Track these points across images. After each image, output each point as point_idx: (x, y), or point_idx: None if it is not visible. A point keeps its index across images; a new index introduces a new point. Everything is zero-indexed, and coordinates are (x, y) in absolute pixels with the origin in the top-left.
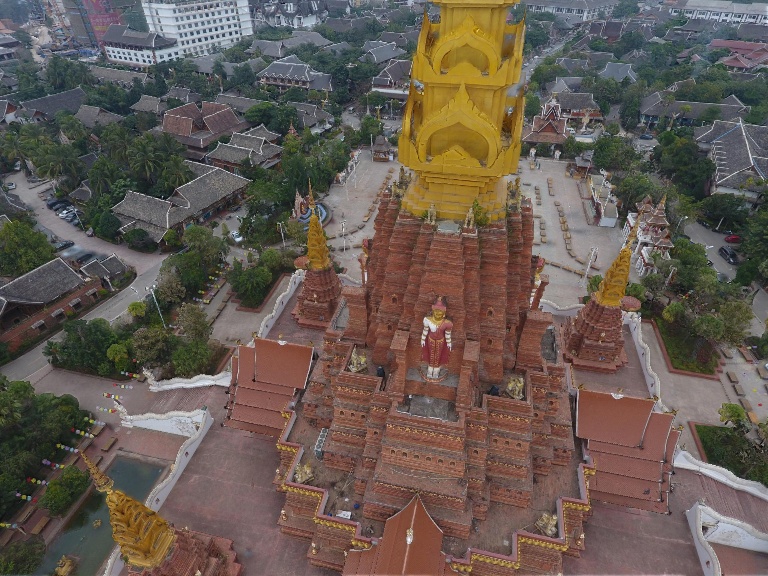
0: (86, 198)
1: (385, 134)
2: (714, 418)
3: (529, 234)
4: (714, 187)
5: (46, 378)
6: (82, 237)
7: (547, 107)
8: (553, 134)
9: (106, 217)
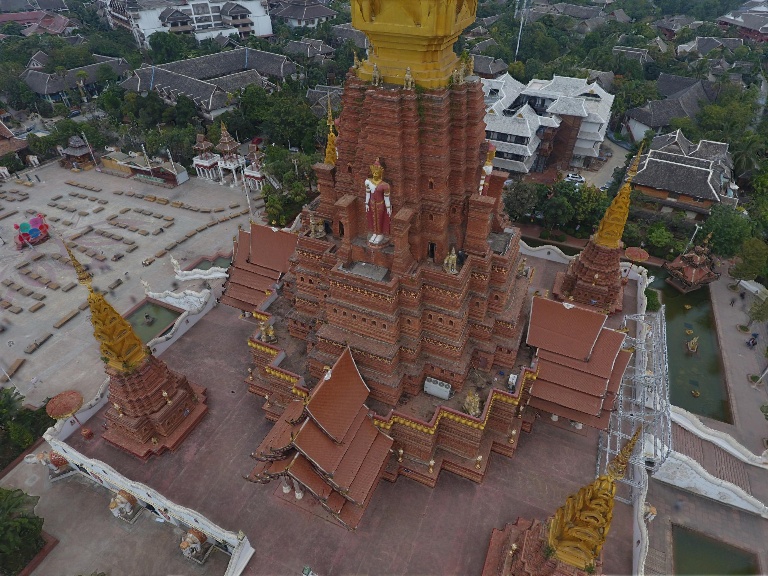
0: None
1: None
2: None
3: None
4: (206, 114)
5: None
6: None
7: None
8: (3, 142)
9: None
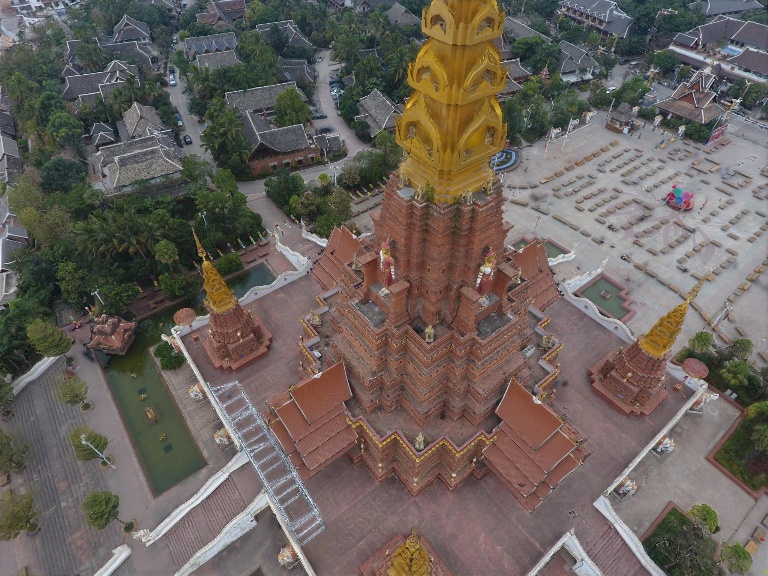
0: (350, 85)
1: (644, 102)
2: None
3: (476, 226)
4: None
5: (260, 200)
6: (334, 114)
7: None
8: None
9: (351, 105)
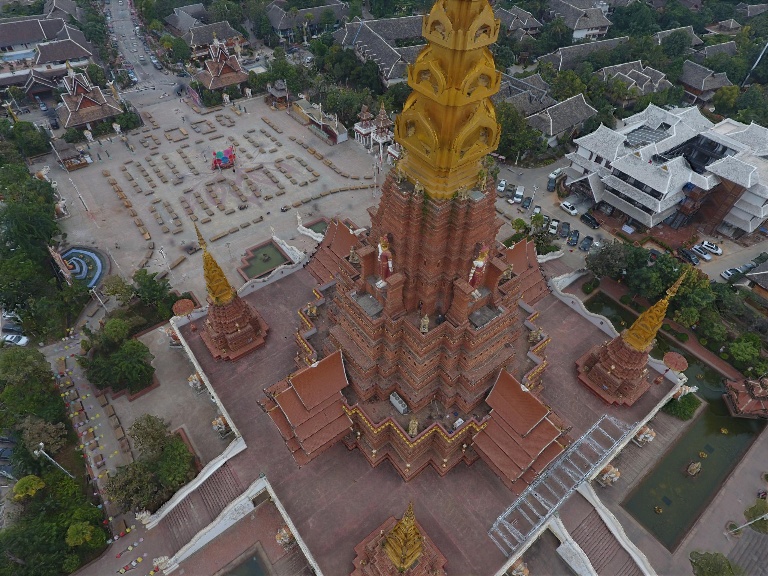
0: None
1: None
2: (504, 234)
3: None
4: (385, 81)
5: None
6: None
7: (213, 49)
8: (232, 74)
9: None
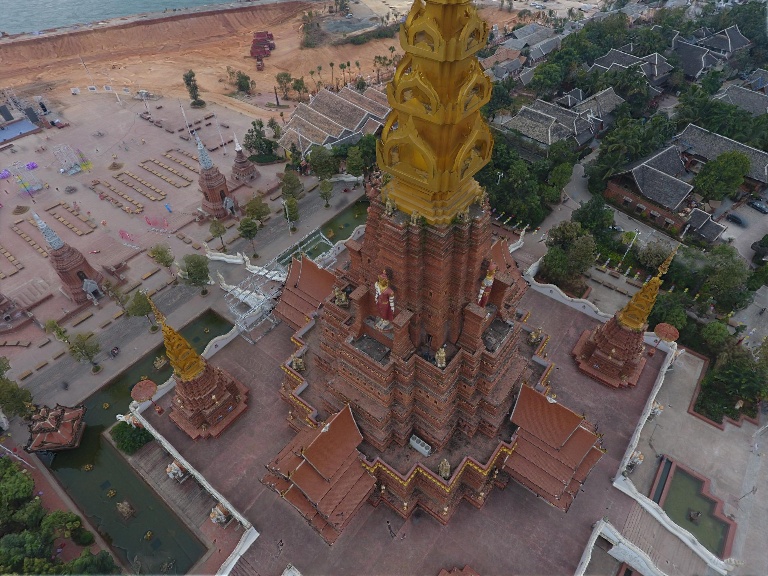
0: None
1: None
2: None
3: None
4: None
5: None
6: None
7: None
8: None
9: None
